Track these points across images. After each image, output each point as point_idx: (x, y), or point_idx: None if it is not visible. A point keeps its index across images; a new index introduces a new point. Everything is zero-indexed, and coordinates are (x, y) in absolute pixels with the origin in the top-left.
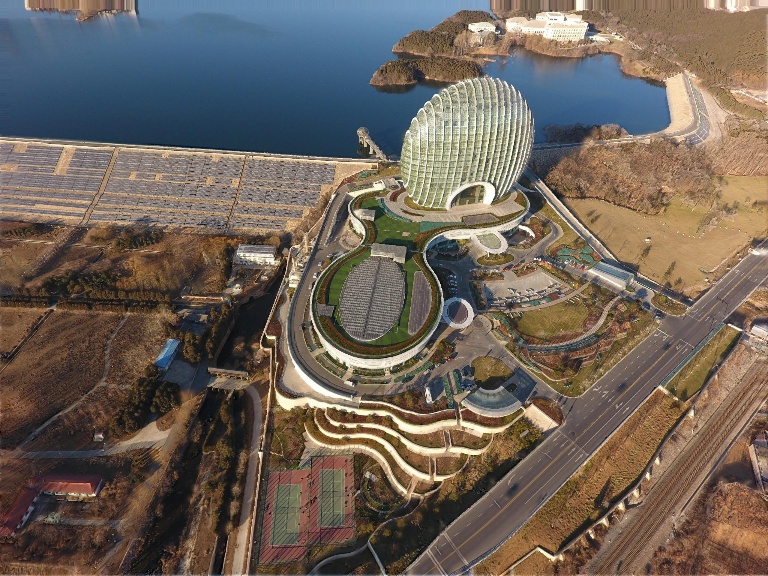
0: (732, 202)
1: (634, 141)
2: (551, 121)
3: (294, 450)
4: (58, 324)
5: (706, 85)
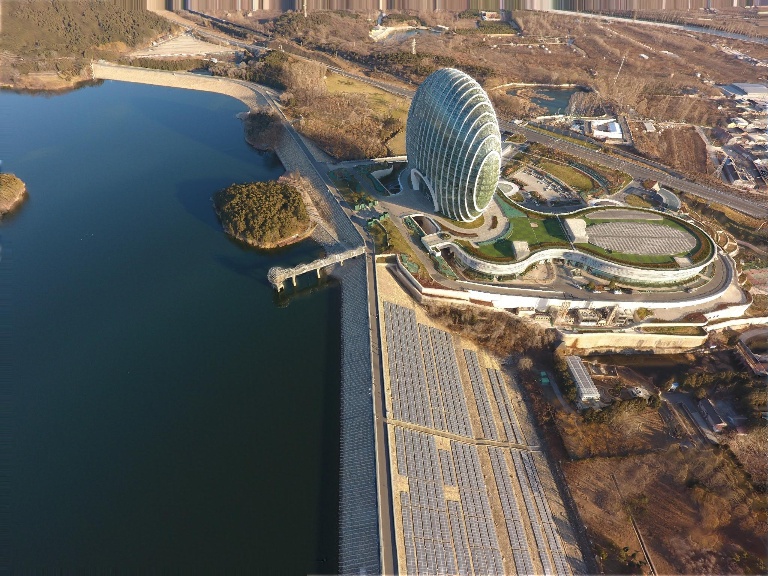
0: (370, 99)
1: (280, 109)
2: (203, 145)
3: (767, 298)
4: None
5: (125, 63)
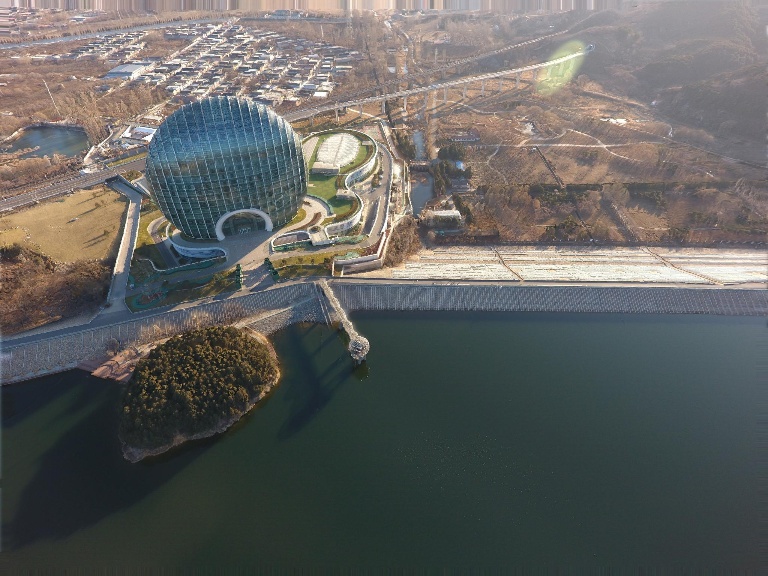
0: None
1: None
2: None
3: None
4: (547, 182)
5: None
